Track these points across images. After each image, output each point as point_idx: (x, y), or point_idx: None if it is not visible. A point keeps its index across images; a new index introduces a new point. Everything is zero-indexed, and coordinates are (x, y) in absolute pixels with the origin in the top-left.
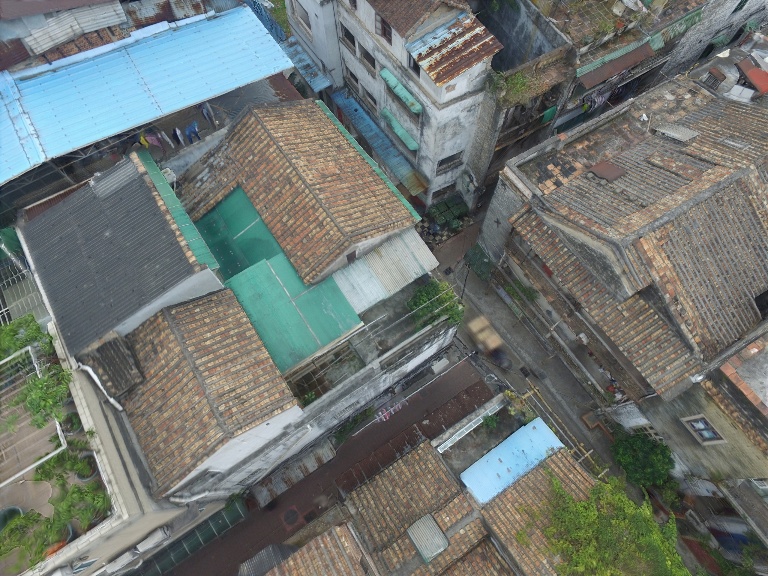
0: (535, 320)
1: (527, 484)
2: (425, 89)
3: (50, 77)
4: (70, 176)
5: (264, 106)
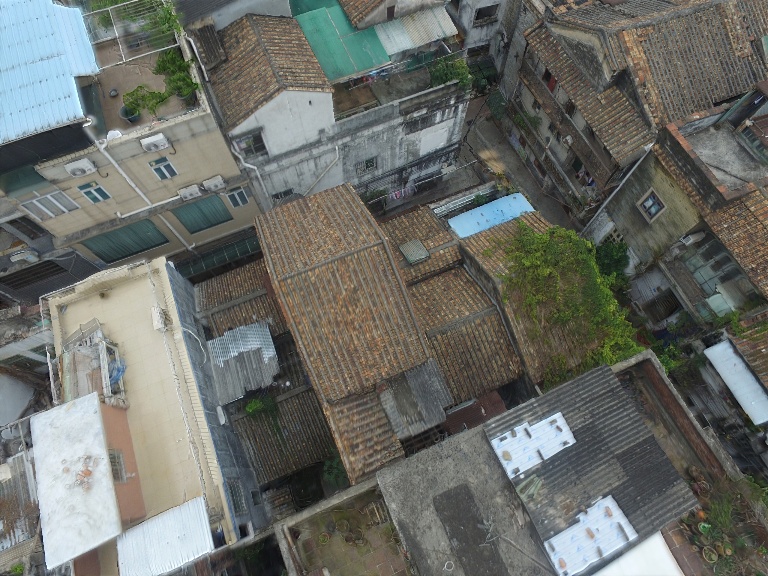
0: (535, 146)
1: (500, 228)
2: None
3: None
4: None
5: None
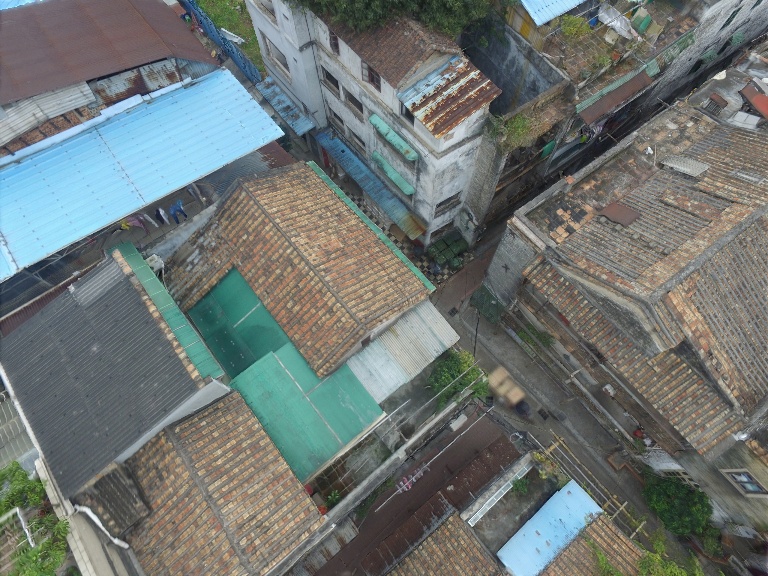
0: (552, 365)
1: (570, 559)
2: (421, 137)
3: (14, 170)
4: (46, 279)
5: (254, 178)
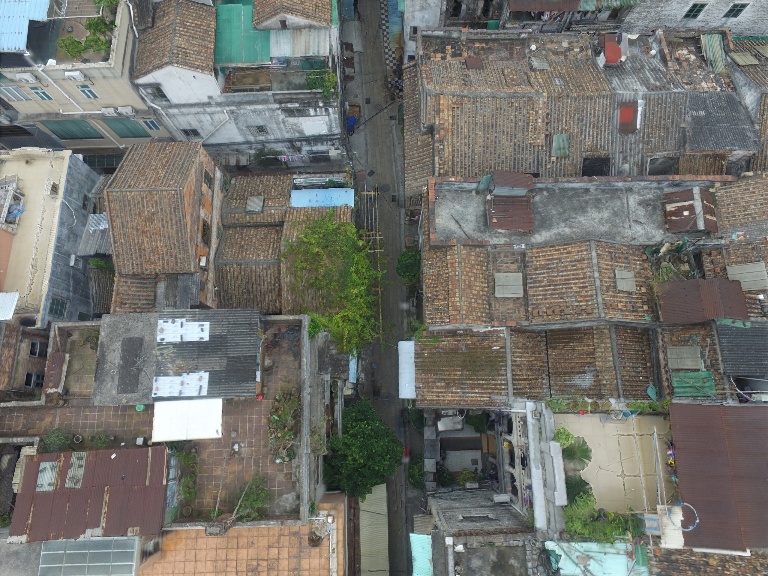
0: None
1: (319, 209)
2: None
3: None
4: None
5: None
